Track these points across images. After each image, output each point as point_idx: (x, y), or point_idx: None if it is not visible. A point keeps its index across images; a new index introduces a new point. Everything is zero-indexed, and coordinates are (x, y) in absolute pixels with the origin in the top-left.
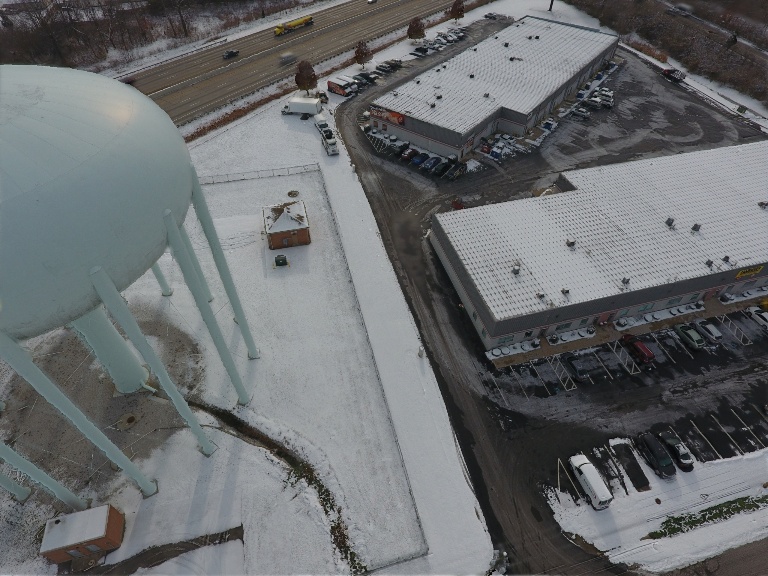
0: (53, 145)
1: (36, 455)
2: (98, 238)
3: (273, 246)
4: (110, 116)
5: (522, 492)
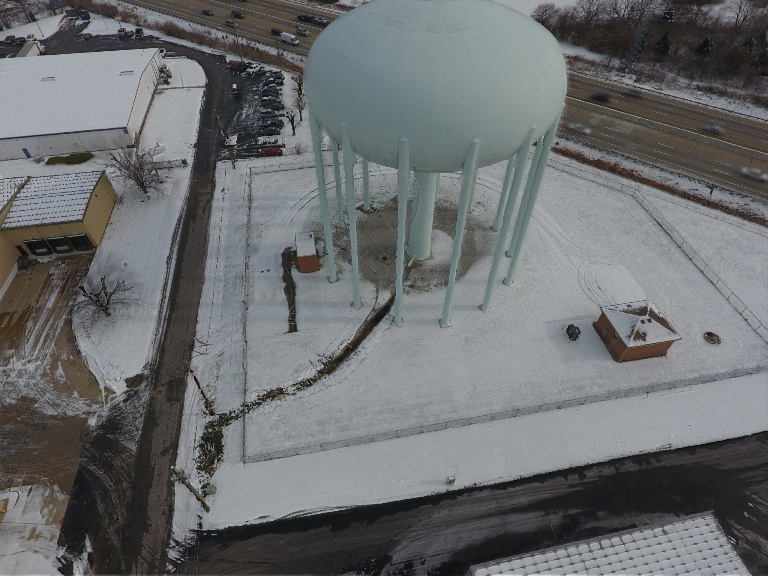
0: (400, 54)
1: (365, 223)
2: (354, 110)
3: (597, 324)
4: (454, 66)
5: (271, 575)
